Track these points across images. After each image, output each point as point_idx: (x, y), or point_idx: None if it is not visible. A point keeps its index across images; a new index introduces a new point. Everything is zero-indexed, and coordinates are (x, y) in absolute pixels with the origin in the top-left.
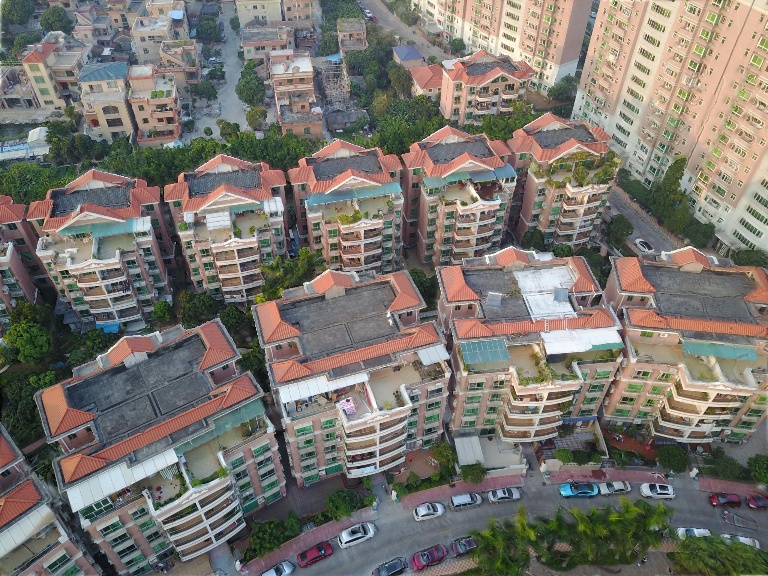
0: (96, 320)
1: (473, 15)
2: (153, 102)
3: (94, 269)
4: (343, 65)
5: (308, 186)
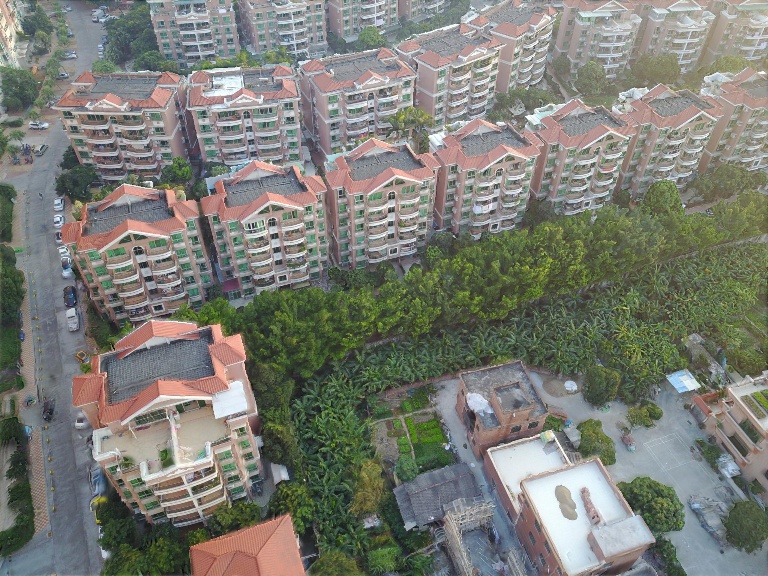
0: None
1: None
2: None
3: None
4: None
5: None
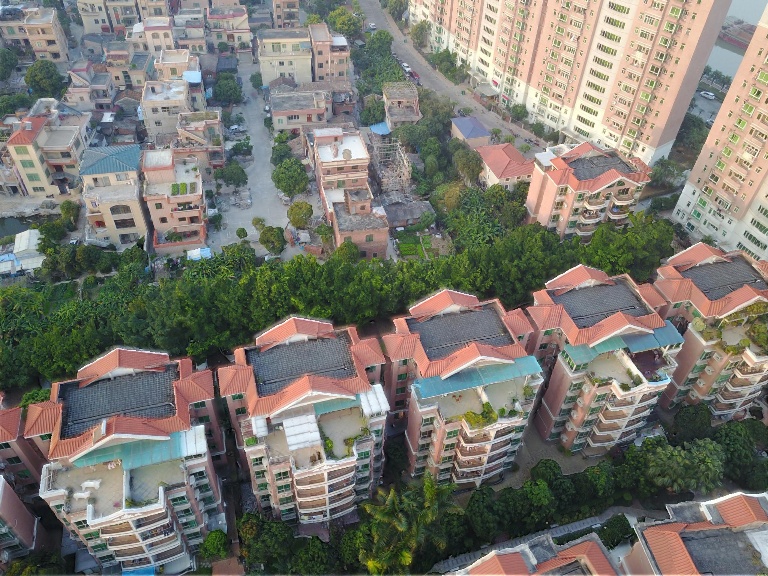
0: (122, 566)
1: (542, 81)
2: (175, 200)
3: (126, 519)
4: (399, 145)
5: (412, 361)
